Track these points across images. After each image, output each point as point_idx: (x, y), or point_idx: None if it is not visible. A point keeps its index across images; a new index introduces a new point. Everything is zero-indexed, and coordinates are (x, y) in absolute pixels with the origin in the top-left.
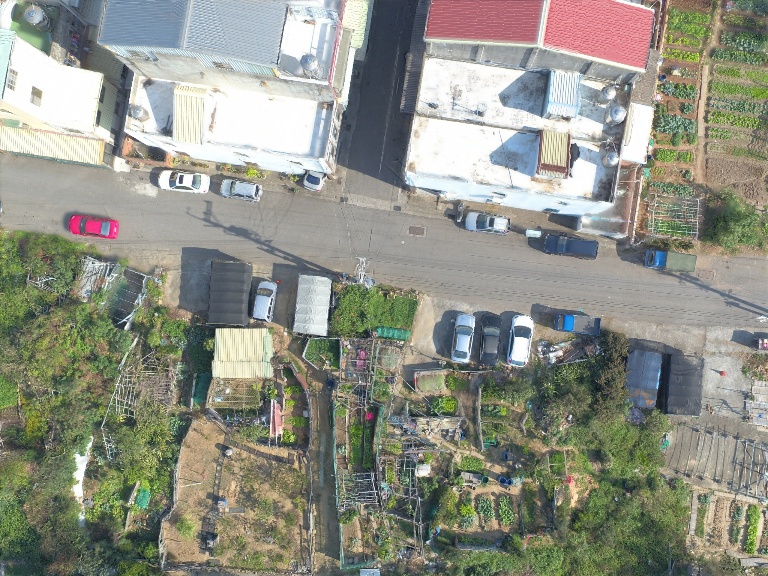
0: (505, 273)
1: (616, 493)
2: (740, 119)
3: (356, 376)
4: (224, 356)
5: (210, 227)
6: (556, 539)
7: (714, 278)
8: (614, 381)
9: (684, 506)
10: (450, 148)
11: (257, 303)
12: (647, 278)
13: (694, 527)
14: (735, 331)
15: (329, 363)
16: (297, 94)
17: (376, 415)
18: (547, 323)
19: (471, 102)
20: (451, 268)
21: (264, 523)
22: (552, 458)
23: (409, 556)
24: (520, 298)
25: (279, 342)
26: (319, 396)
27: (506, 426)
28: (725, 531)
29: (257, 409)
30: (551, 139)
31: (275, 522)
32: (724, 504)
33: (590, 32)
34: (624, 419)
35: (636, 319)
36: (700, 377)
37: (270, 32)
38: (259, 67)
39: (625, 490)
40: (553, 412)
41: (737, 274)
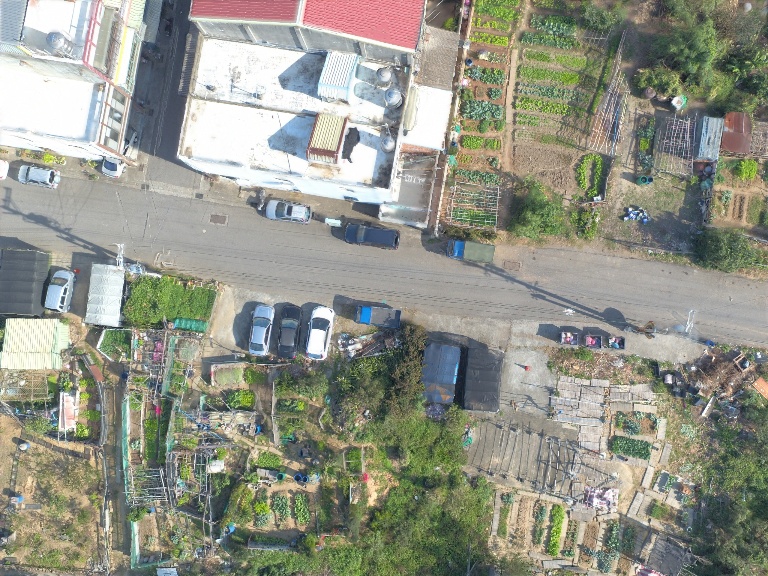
0: (307, 263)
1: (415, 491)
2: (548, 105)
3: (147, 368)
4: (13, 347)
5: (9, 214)
6: (348, 539)
7: (520, 269)
8: (408, 375)
9: (487, 506)
10: (228, 132)
11: (49, 292)
12: (452, 269)
13: (496, 527)
14: (541, 324)
15: (125, 355)
16: (67, 75)
17: (171, 409)
18: (349, 315)
19: (250, 84)
20: (252, 258)
21: (61, 520)
22: (349, 455)
23: (204, 555)
24: (322, 289)
25: (76, 333)
26: (116, 389)
27: (303, 421)
28: (528, 532)
29: (50, 402)
30: (326, 123)
31: (72, 519)
32: (527, 504)
33: (356, 11)
34: (425, 415)
35: (440, 311)
36: (497, 372)
37: (12, 8)
38: (4, 45)
39: (424, 488)
40: (348, 407)
41: (543, 265)
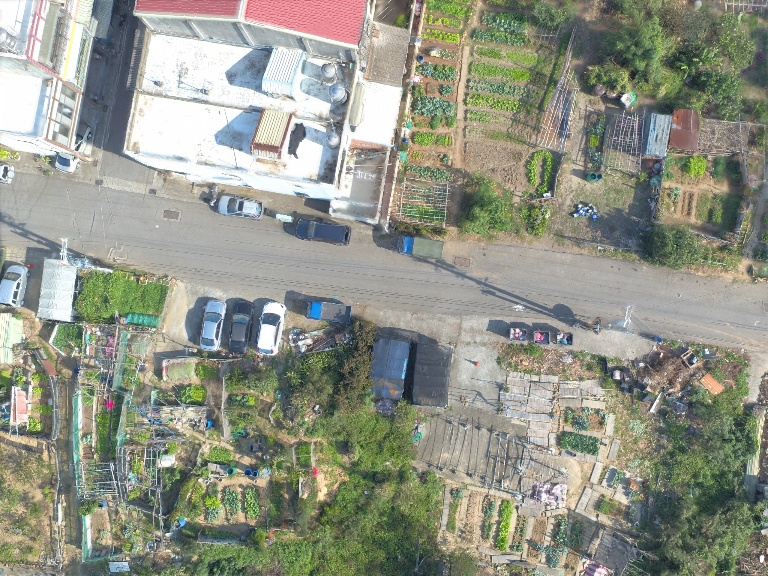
0: (259, 259)
1: (365, 486)
2: (499, 102)
3: (98, 363)
4: None
5: None
6: (296, 533)
7: (470, 266)
8: (357, 370)
9: (436, 500)
10: (175, 127)
11: (2, 287)
12: (403, 265)
13: (446, 522)
14: (491, 320)
15: (78, 350)
16: (15, 70)
17: None
18: (301, 311)
19: (197, 80)
20: (205, 253)
21: (14, 514)
22: (299, 449)
23: (156, 549)
24: (274, 285)
25: (30, 328)
26: (68, 384)
27: (254, 416)
28: (477, 527)
29: (2, 396)
30: (271, 118)
31: (25, 513)
32: (477, 499)
33: (298, 7)
34: (375, 410)
35: (391, 307)
36: (446, 367)
37: None
38: None
39: (374, 483)
40: (297, 402)
41: (494, 262)
